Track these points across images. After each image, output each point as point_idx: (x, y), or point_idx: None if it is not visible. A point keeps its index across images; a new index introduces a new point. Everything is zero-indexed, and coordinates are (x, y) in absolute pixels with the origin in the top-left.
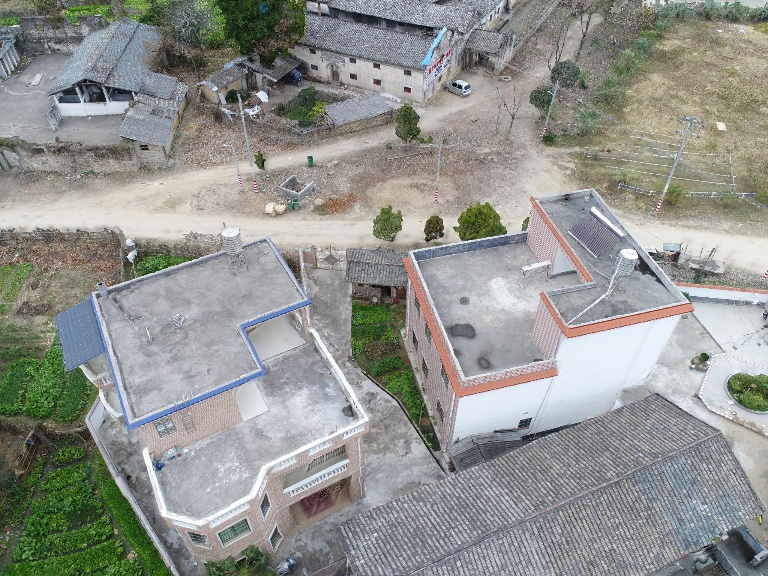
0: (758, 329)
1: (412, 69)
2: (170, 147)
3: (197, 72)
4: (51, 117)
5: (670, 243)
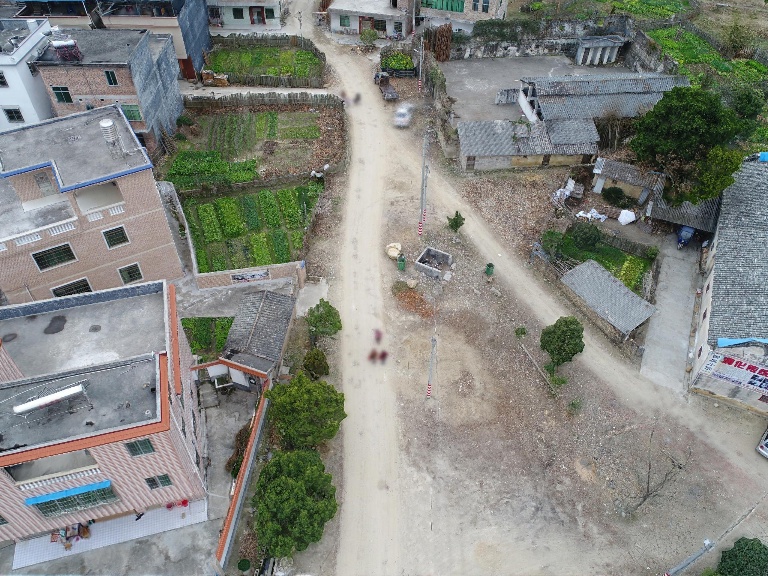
0: None
1: None
2: (492, 169)
3: None
4: (502, 93)
5: None
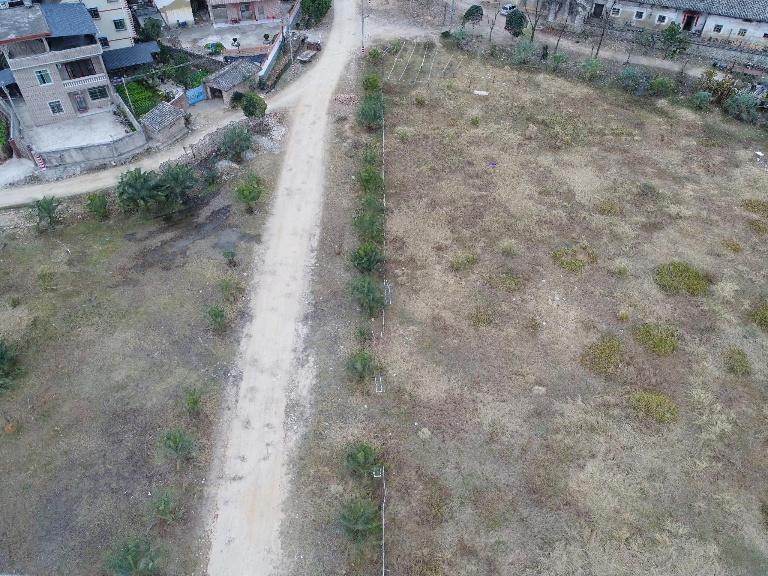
0: None
1: None
2: None
3: None
4: None
5: (317, 41)
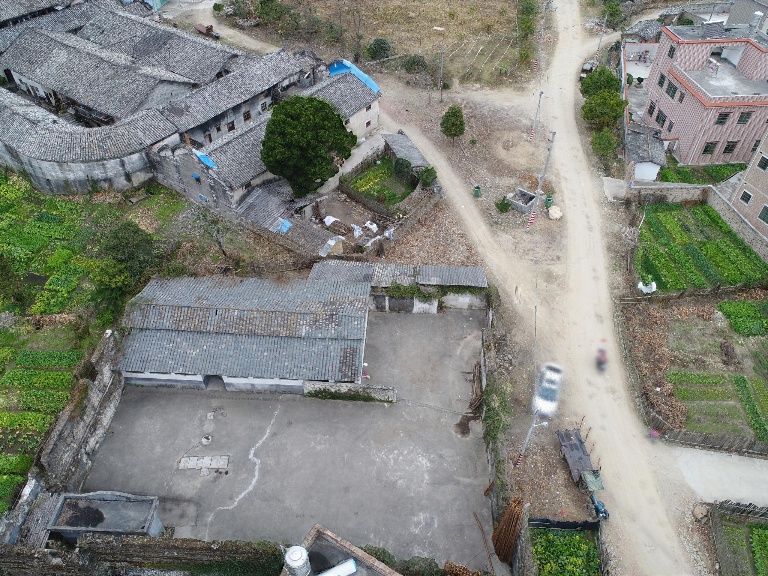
0: (639, 66)
1: (373, 101)
2: None
3: (246, 273)
4: None
5: (584, 66)
